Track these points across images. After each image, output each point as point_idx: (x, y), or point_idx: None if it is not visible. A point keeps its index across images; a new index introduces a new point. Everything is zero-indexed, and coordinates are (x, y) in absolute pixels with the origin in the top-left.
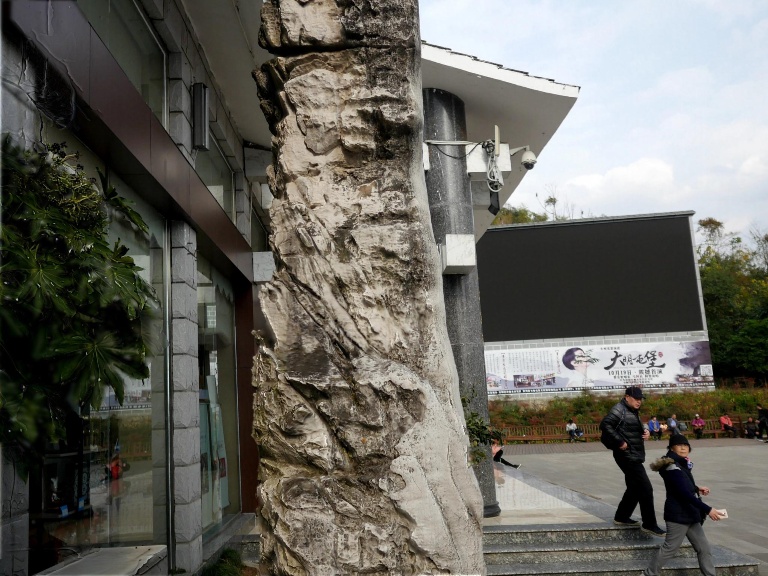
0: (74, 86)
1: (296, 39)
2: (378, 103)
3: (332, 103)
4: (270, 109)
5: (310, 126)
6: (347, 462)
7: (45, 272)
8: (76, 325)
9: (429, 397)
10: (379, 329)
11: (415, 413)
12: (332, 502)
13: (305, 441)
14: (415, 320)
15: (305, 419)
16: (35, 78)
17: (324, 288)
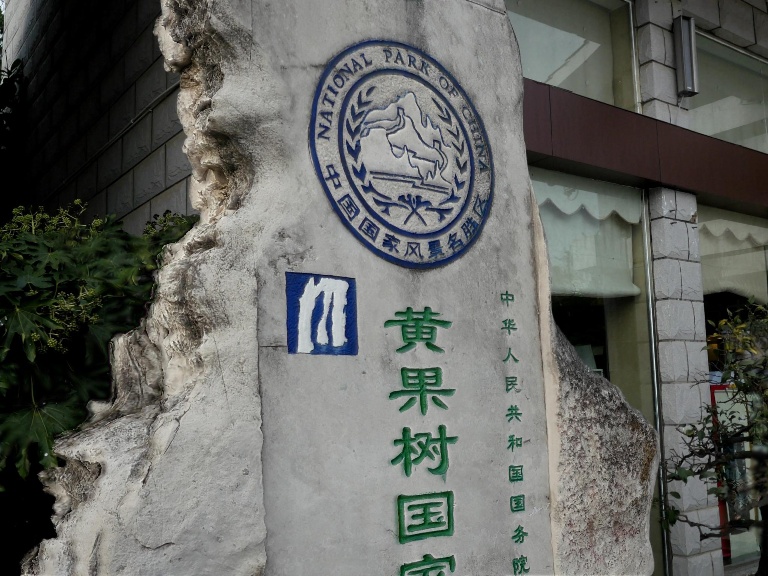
0: None
1: (164, 66)
2: None
3: None
4: None
5: None
6: None
7: None
8: None
9: (108, 472)
10: (167, 381)
11: None
12: None
13: None
14: None
15: (44, 482)
16: None
17: (160, 334)
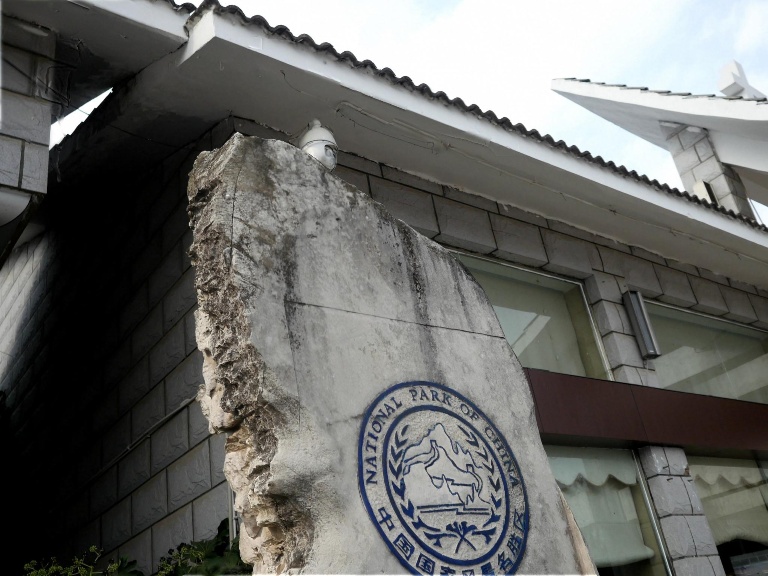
0: None
1: (212, 432)
2: (261, 474)
3: (244, 484)
4: None
5: None
6: None
7: None
8: None
9: None
10: None
11: None
12: None
13: None
14: None
15: None
16: None
17: None
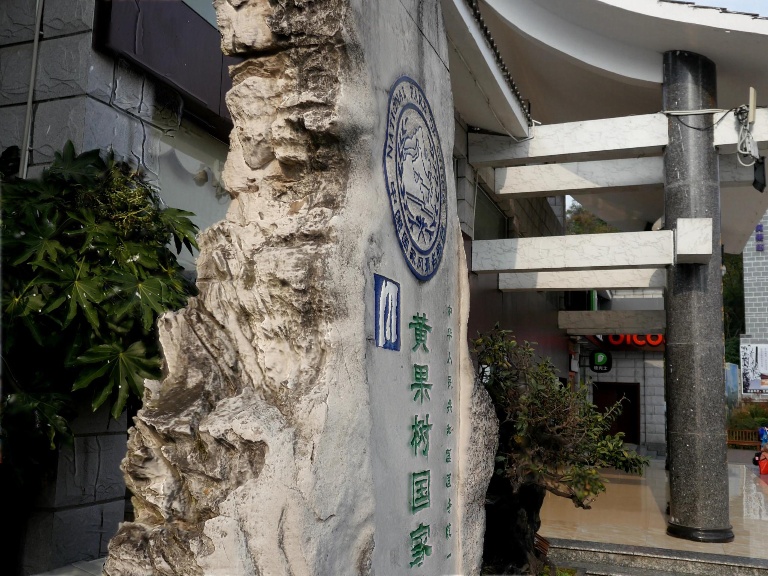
0: (190, 97)
1: (229, 47)
2: (306, 110)
3: (264, 113)
4: None
5: (244, 139)
6: (190, 512)
7: (80, 283)
8: (106, 334)
9: (276, 450)
10: (271, 364)
11: (258, 467)
12: (151, 556)
13: (147, 485)
14: (318, 355)
15: (144, 463)
16: (129, 95)
17: (230, 316)
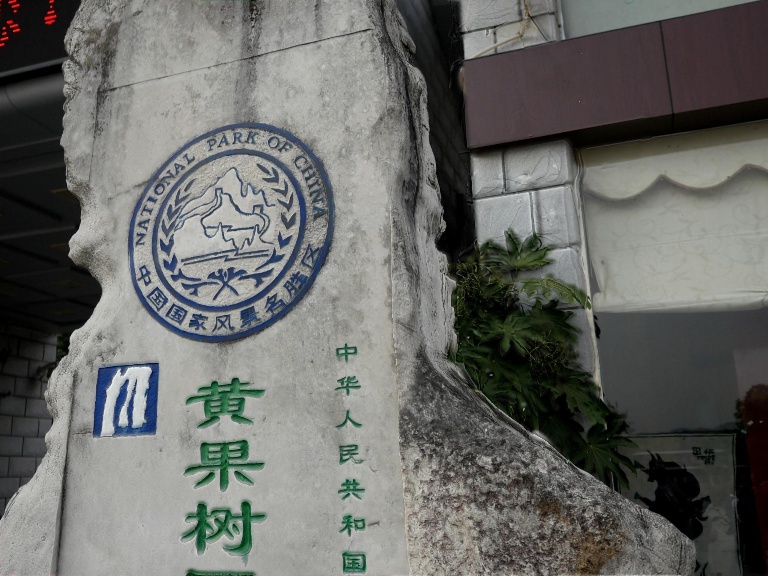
0: (597, 129)
1: None
2: None
3: None
4: None
5: None
6: None
7: None
8: None
9: None
10: None
11: None
12: None
13: None
14: None
15: None
16: (490, 182)
17: None
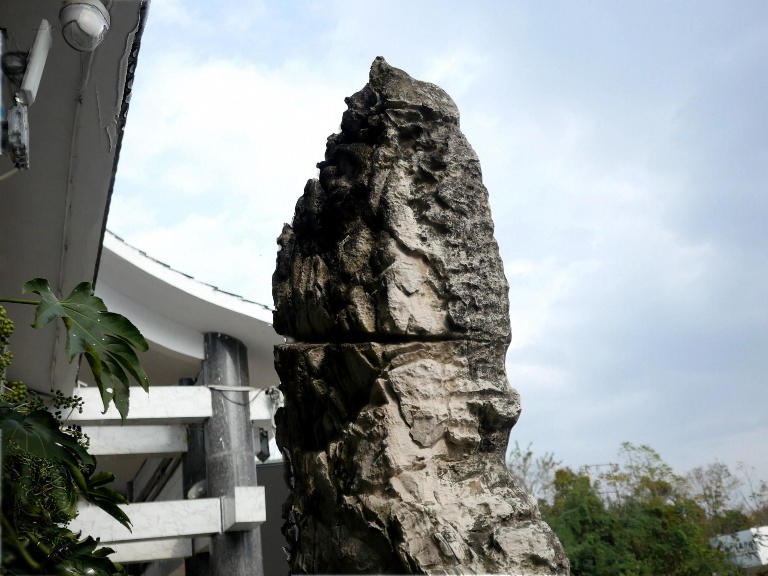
0: None
1: (404, 328)
2: (484, 396)
3: (439, 394)
4: (321, 389)
5: (420, 417)
6: None
7: None
8: None
9: None
10: None
11: None
12: None
13: None
14: None
15: None
16: None
17: None
